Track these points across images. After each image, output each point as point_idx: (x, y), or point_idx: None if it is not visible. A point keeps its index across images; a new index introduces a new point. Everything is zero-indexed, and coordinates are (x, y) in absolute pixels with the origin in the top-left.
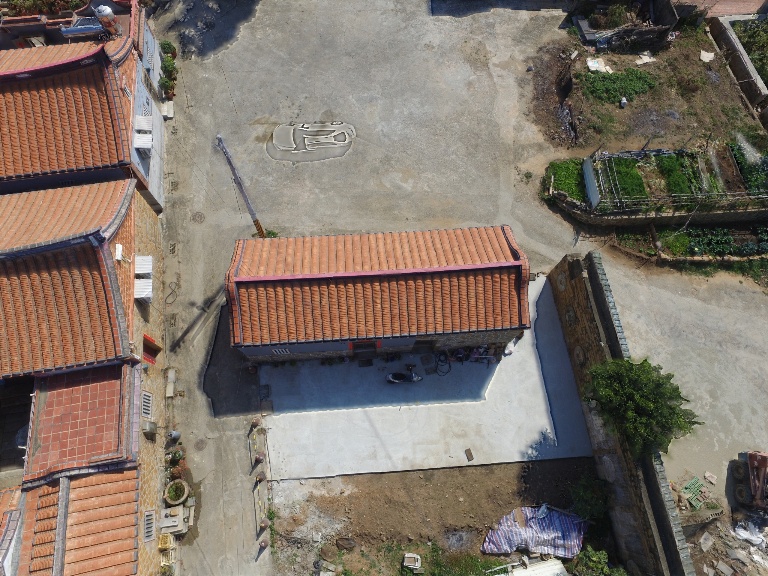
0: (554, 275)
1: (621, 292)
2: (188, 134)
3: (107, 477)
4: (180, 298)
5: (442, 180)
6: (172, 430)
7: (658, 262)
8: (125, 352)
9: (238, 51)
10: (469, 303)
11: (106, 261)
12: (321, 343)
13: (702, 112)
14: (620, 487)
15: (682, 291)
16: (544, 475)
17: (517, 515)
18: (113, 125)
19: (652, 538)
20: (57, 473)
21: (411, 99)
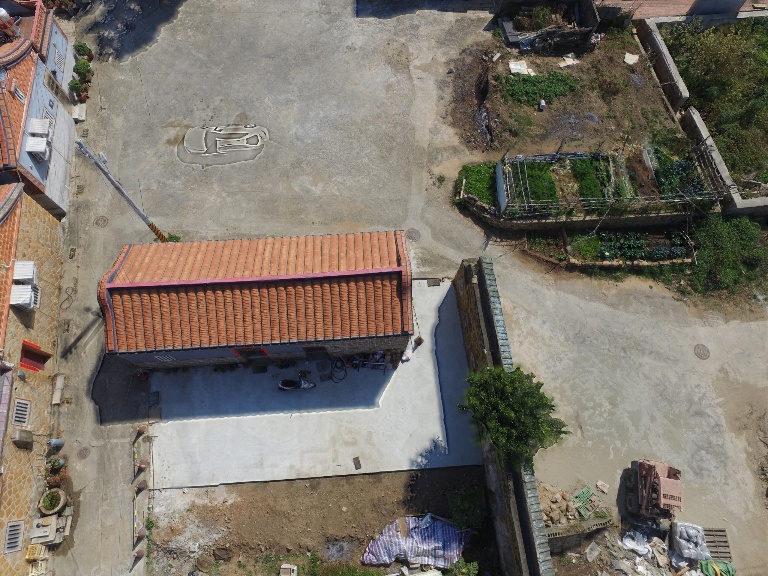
0: (457, 280)
1: (528, 297)
2: (99, 137)
3: None
4: (76, 303)
5: (352, 184)
6: (54, 438)
7: (568, 267)
8: None
9: (157, 53)
10: (350, 309)
11: None
12: (200, 350)
13: (621, 115)
14: (498, 497)
15: (590, 296)
16: (432, 484)
17: (400, 525)
18: None
19: (517, 550)
20: None
21: (328, 102)
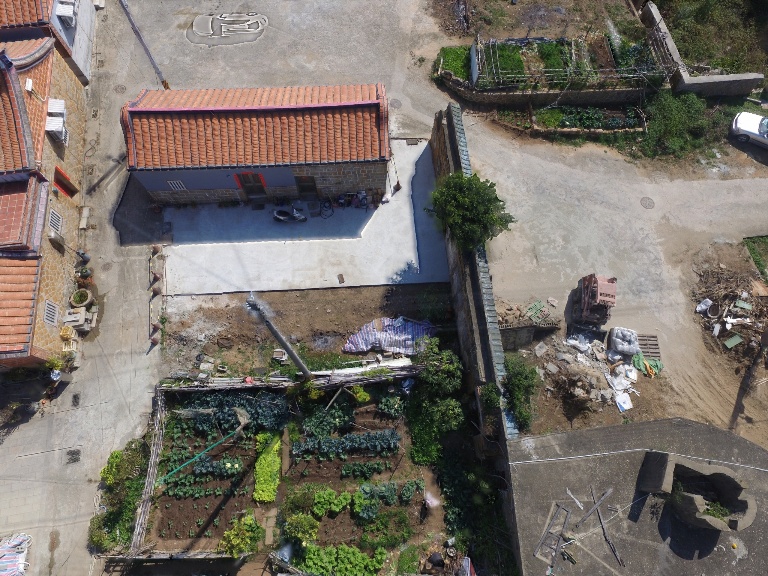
0: (432, 138)
1: (495, 157)
2: (117, 22)
3: (10, 262)
4: (98, 152)
5: (342, 62)
6: None
7: (532, 134)
8: (31, 165)
9: None
10: (335, 137)
11: (13, 84)
12: (207, 172)
13: (586, 8)
14: (459, 292)
15: (551, 158)
16: (405, 295)
17: (376, 324)
18: None
19: (470, 318)
20: None
21: None
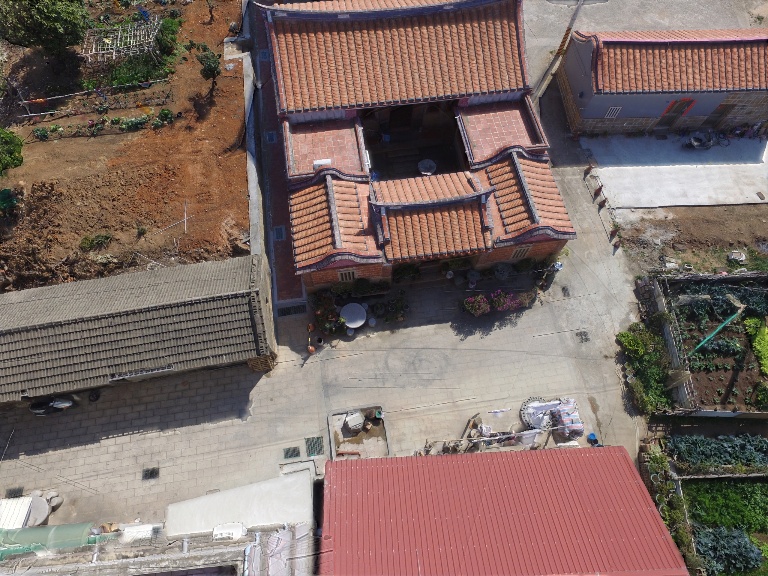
0: None
1: None
2: None
3: (533, 163)
4: None
5: (692, 19)
6: None
7: None
8: (530, 85)
9: None
10: None
11: (521, 15)
12: (656, 97)
13: None
14: None
15: None
16: None
17: None
18: None
19: None
20: (510, 149)
21: None
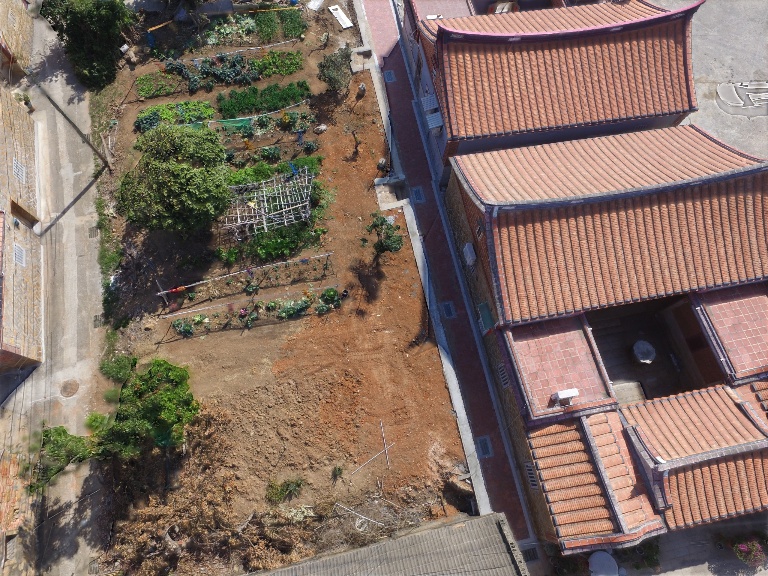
0: None
1: None
2: None
3: None
4: None
5: None
6: None
7: None
8: None
9: None
10: None
11: None
12: None
13: None
14: None
15: None
16: None
17: None
18: (688, 74)
19: None
20: None
21: None
